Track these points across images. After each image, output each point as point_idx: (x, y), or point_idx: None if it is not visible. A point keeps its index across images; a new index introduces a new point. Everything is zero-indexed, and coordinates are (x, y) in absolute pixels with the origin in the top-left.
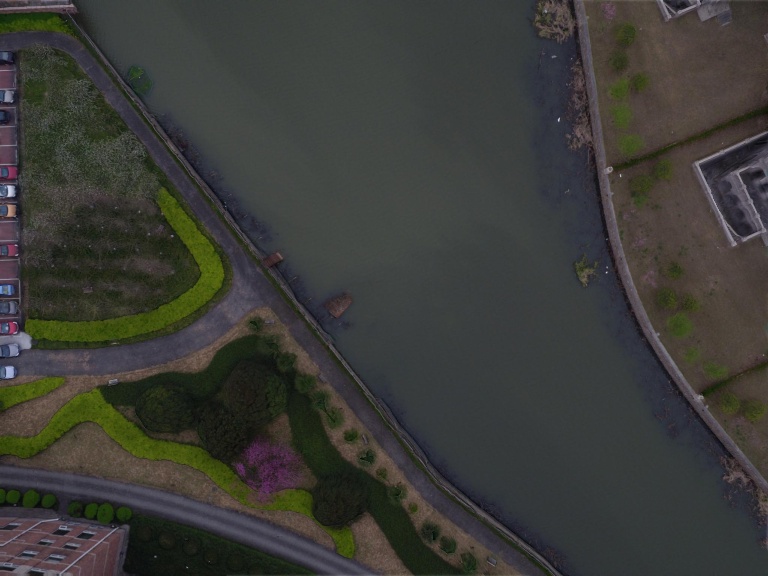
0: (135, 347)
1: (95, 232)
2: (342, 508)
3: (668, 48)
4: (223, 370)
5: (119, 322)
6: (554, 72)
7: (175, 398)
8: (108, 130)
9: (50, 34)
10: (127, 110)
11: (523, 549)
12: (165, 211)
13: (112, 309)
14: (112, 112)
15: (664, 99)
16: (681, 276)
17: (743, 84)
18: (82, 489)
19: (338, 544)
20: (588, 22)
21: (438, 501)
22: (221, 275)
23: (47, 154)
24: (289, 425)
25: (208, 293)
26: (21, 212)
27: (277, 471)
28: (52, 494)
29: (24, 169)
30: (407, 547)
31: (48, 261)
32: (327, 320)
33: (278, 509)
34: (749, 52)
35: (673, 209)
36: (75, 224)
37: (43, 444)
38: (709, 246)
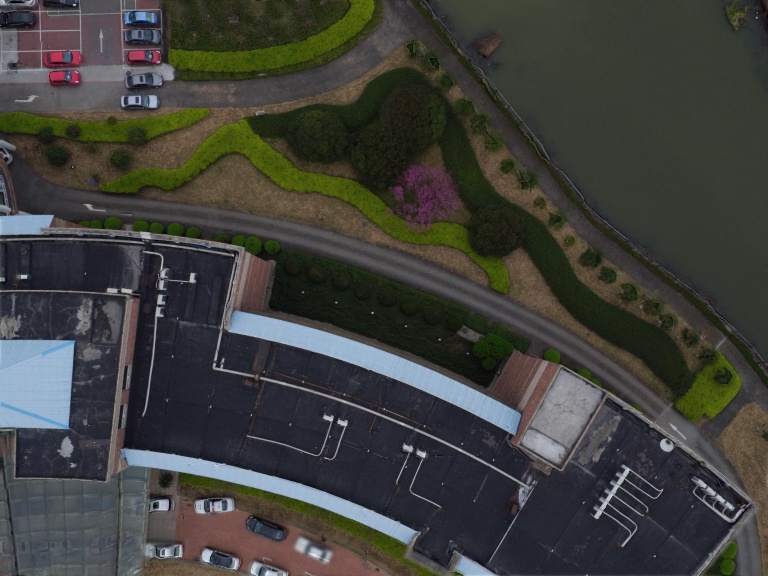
0: (282, 79)
1: None
2: (506, 228)
3: None
4: (376, 99)
5: (267, 52)
6: None
7: (333, 116)
8: None
9: None
10: None
11: (682, 283)
12: None
13: (258, 40)
14: None
15: None
16: None
17: None
18: (227, 223)
19: (493, 278)
20: None
21: (593, 238)
22: (371, 6)
23: None
24: (442, 159)
25: (358, 24)
26: None
27: (435, 196)
28: (197, 227)
29: None
30: (564, 281)
31: None
32: (476, 60)
33: (431, 243)
34: None
35: None
36: None
37: (188, 175)
38: None
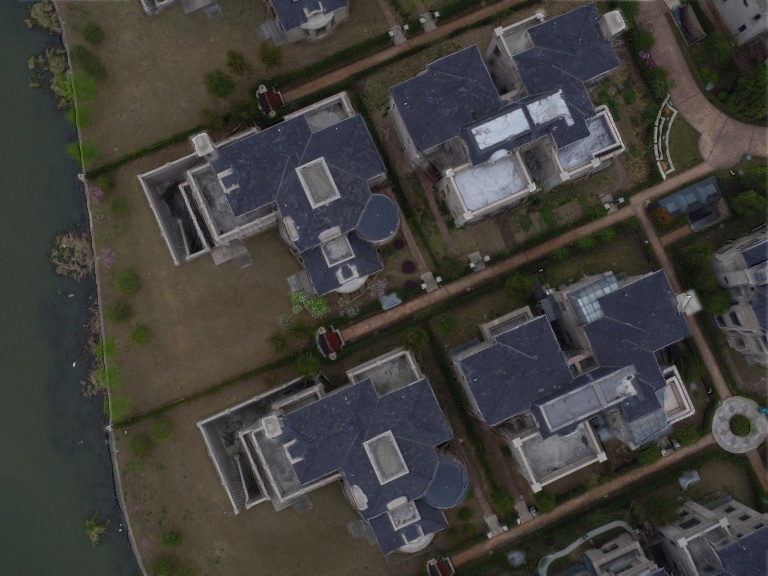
0: None
1: None
2: None
3: (180, 294)
4: None
5: None
6: (71, 312)
7: None
8: None
9: None
10: None
11: None
12: None
13: None
14: None
15: (172, 350)
16: (184, 543)
17: (259, 334)
18: None
19: None
20: (98, 263)
21: None
22: None
23: None
24: None
25: None
26: None
27: None
28: None
29: None
30: None
31: None
32: None
33: None
34: (270, 297)
35: (179, 470)
36: None
37: None
38: (216, 511)
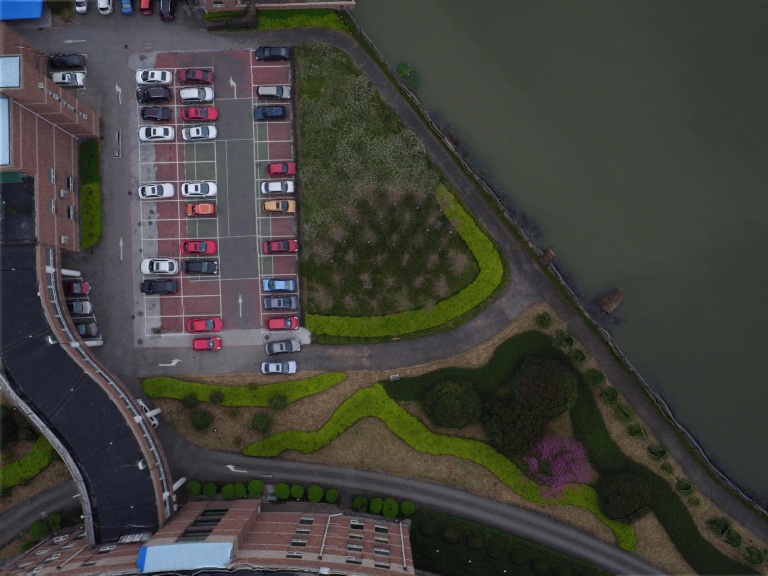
0: (415, 342)
1: (374, 228)
2: (638, 502)
3: None
4: (507, 365)
5: (400, 317)
6: None
7: (471, 393)
8: (387, 126)
9: (324, 30)
10: (402, 106)
11: None
12: (444, 207)
13: (392, 304)
14: (388, 108)
15: None
16: None
17: None
18: (363, 484)
19: (621, 538)
20: None
21: (716, 495)
22: (501, 271)
23: (328, 150)
24: (570, 420)
25: (488, 289)
26: (299, 207)
27: (567, 465)
28: (334, 489)
29: (301, 165)
30: (689, 541)
31: (329, 256)
32: (599, 316)
33: (560, 503)
34: None
35: None
36: (355, 220)
37: (326, 439)
38: None
